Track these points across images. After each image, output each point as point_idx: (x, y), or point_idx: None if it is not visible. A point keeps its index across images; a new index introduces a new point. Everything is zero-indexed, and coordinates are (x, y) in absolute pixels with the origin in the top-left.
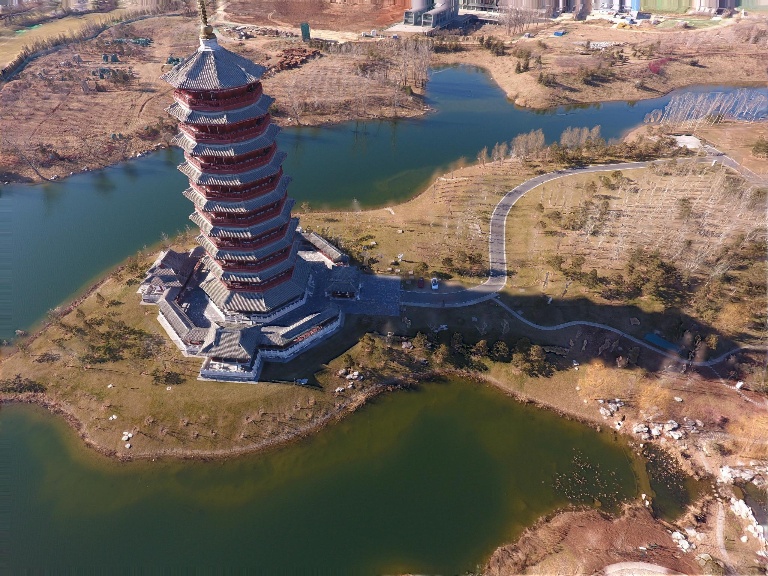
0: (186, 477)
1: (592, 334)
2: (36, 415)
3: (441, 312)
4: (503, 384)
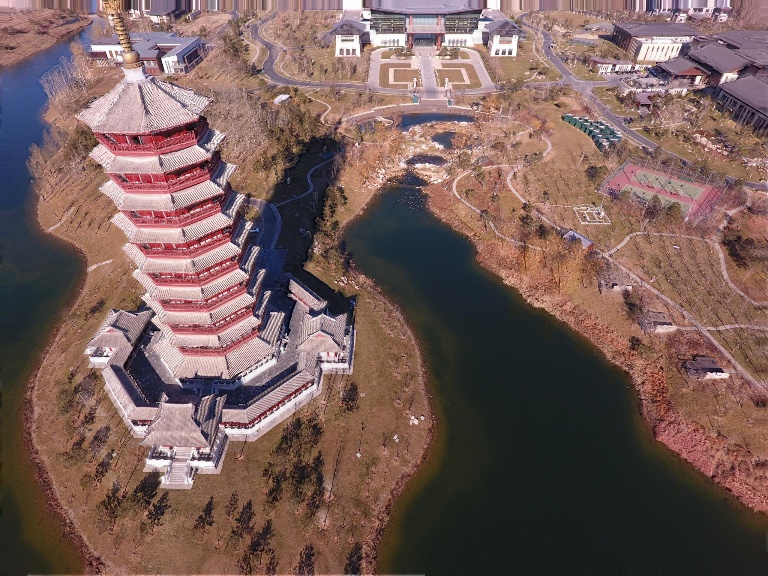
0: (439, 373)
1: (318, 175)
2: (392, 540)
3: (286, 230)
4: (349, 218)
